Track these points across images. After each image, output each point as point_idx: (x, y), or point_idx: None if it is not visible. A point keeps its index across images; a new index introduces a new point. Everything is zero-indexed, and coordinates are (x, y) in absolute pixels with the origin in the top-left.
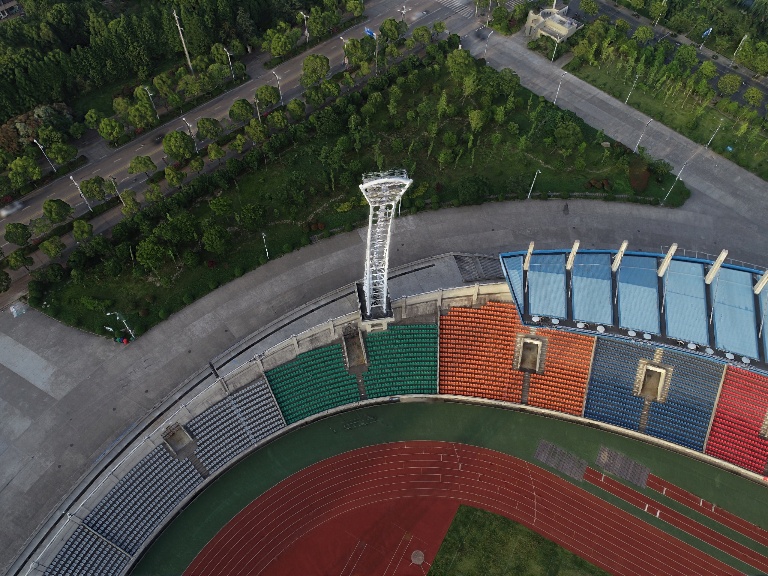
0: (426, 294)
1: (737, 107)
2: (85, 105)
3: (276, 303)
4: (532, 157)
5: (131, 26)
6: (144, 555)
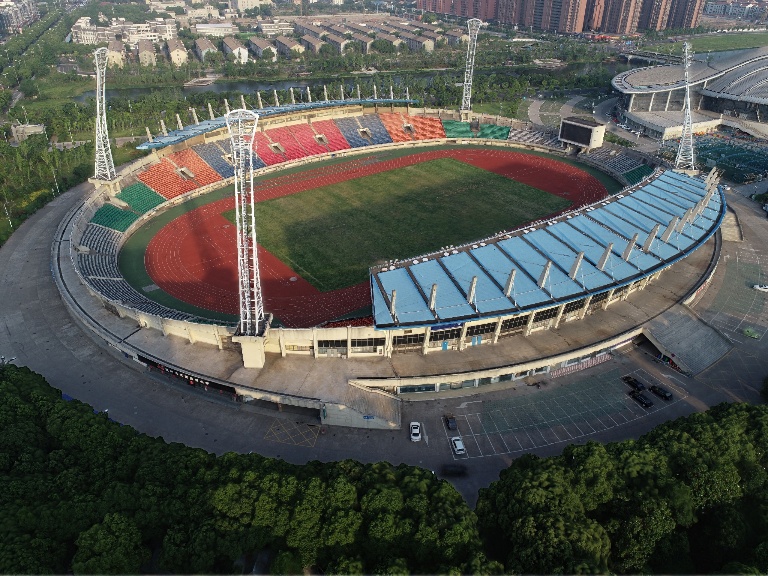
0: (124, 170)
1: (155, 120)
2: None
3: (46, 233)
4: (93, 160)
5: None
6: None
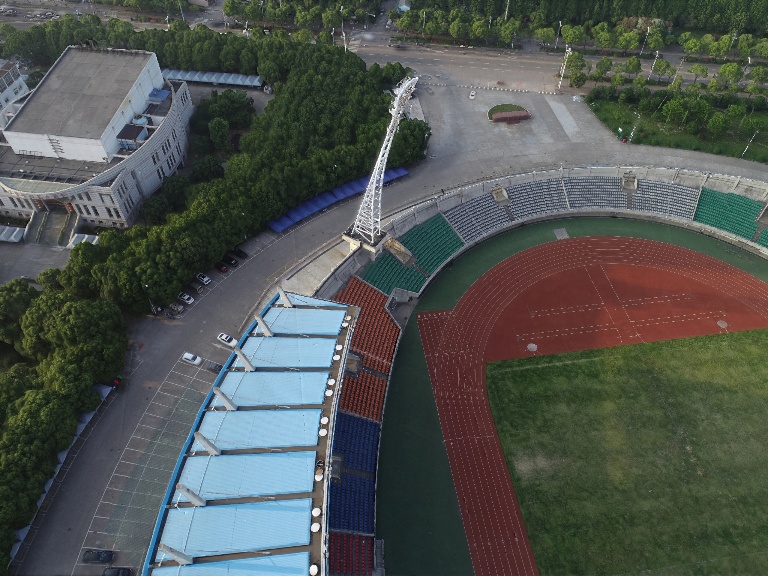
0: None
1: None
2: None
3: None
4: None
5: (751, 1)
6: (571, 218)
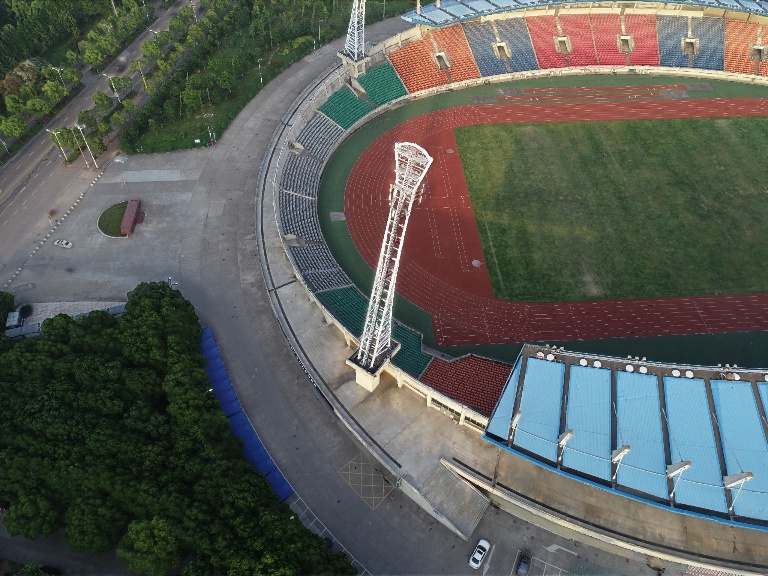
0: (377, 46)
1: None
2: (47, 61)
3: (286, 101)
4: (371, 2)
5: None
6: (317, 205)
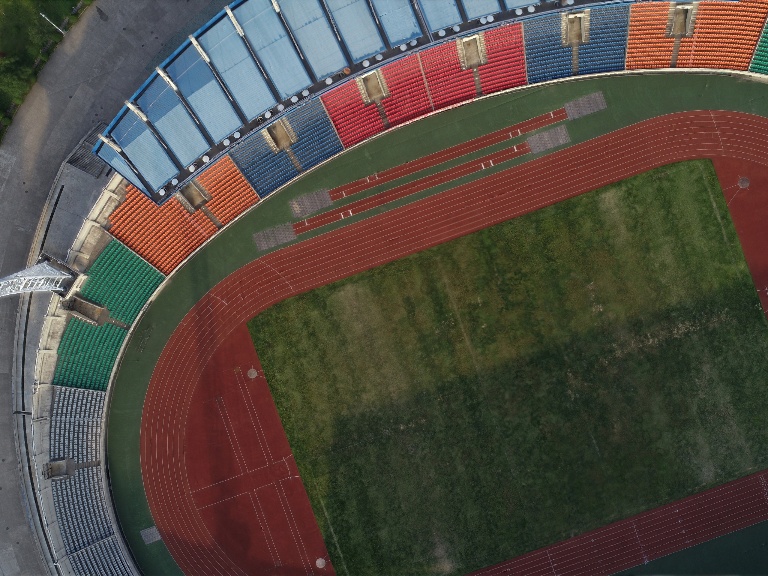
0: (81, 233)
1: None
2: None
3: None
4: None
5: None
6: (120, 524)
